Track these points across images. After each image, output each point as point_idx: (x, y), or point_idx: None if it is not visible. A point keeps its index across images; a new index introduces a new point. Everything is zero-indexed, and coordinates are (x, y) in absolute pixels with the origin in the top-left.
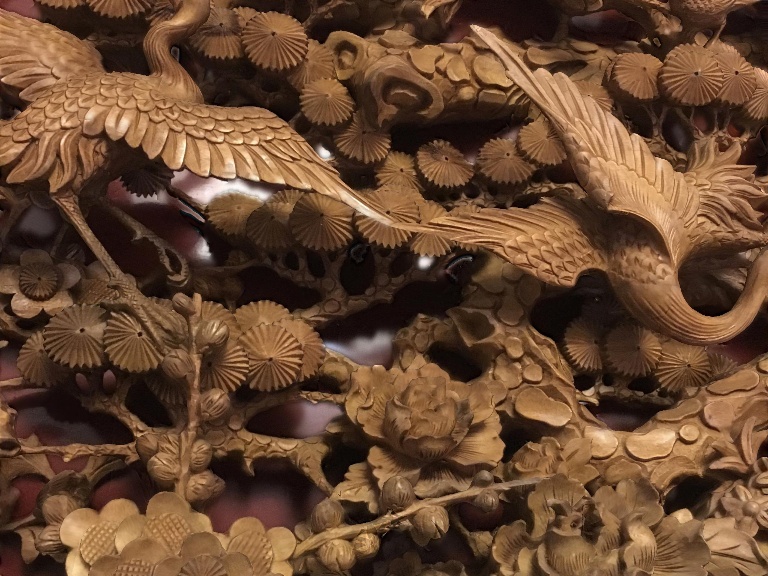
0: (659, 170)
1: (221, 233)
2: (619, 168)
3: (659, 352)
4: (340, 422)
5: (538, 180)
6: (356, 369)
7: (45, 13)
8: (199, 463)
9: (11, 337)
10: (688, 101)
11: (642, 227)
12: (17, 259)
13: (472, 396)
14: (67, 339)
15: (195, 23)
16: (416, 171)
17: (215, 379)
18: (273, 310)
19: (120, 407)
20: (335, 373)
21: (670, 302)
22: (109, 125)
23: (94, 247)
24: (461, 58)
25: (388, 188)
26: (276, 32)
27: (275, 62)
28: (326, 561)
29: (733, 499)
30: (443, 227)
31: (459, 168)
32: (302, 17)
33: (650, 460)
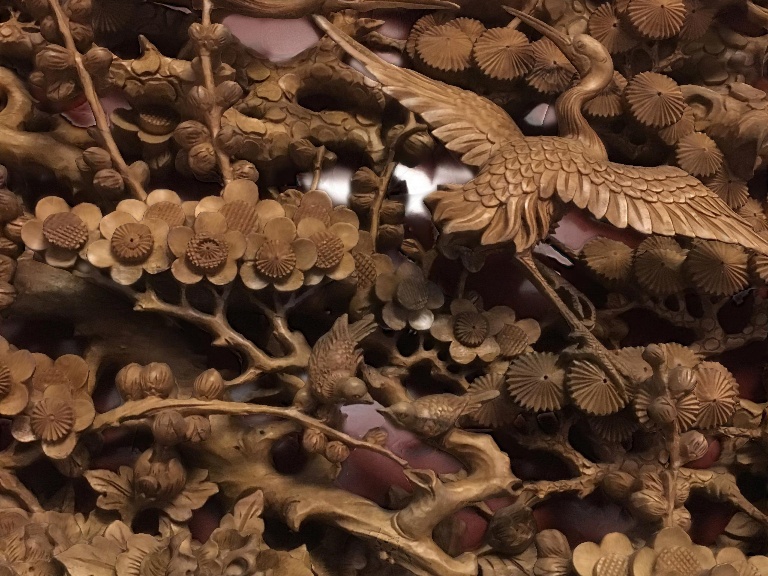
0: None
1: (601, 278)
2: None
3: None
4: (748, 454)
5: None
6: (738, 403)
7: (429, 75)
8: (683, 499)
9: (438, 380)
10: None
11: None
12: (447, 309)
13: None
14: (532, 386)
15: (603, 88)
16: (766, 215)
17: None
18: (683, 352)
19: (566, 445)
20: None
21: None
22: (560, 188)
23: (557, 301)
24: None
25: (763, 235)
26: (662, 92)
27: (658, 119)
28: None
29: None
30: None
31: None
32: (644, 71)
33: None
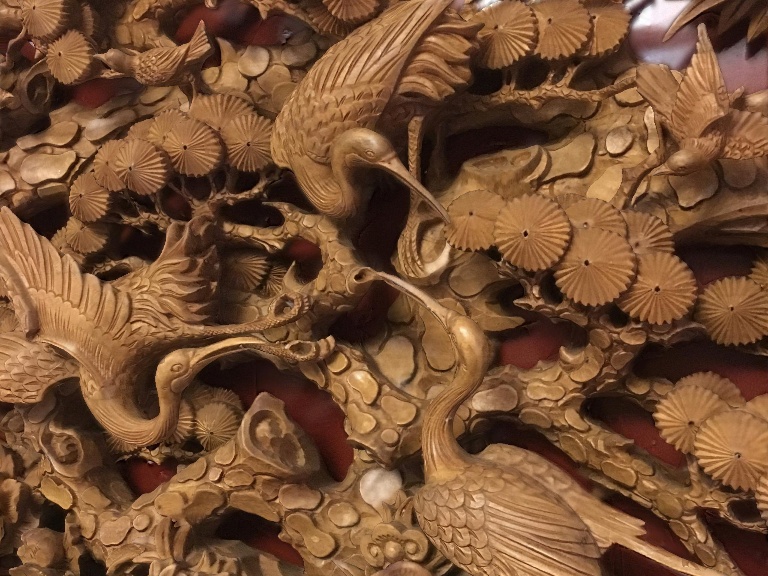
0: (86, 288)
1: None
2: (46, 296)
3: (189, 421)
4: None
5: (99, 261)
6: None
7: None
8: None
9: None
10: (140, 192)
11: None
12: None
13: None
14: None
15: None
16: None
17: None
18: None
19: None
20: None
21: (100, 415)
22: None
23: None
24: (8, 167)
25: None
26: None
27: None
28: None
29: None
30: None
31: None
32: None
33: (110, 546)
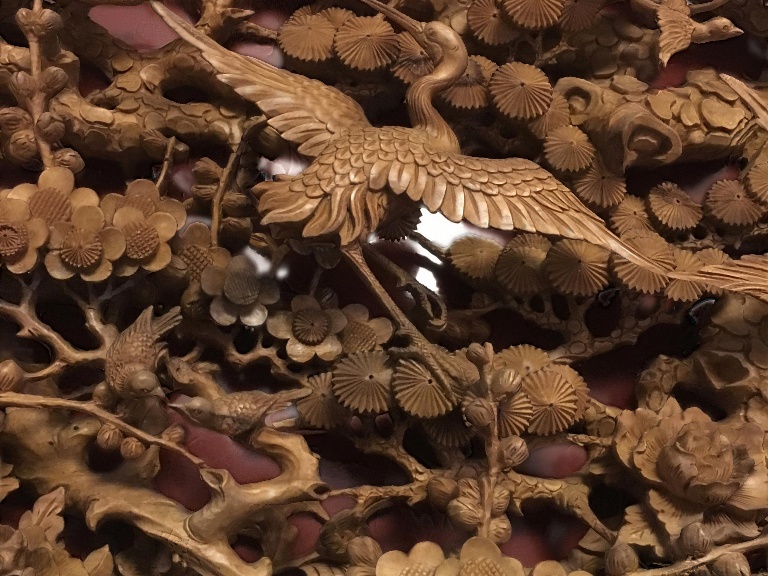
0: None
1: (465, 276)
2: None
3: None
4: (602, 464)
5: (765, 221)
6: (604, 410)
7: (292, 65)
8: (500, 508)
9: (280, 379)
10: None
11: None
12: (288, 305)
13: (740, 440)
14: (357, 385)
15: (455, 77)
16: (648, 214)
17: (502, 425)
18: (534, 354)
19: (399, 449)
20: None
21: None
22: (392, 179)
23: (383, 297)
24: None
25: (633, 233)
26: (525, 83)
27: (522, 111)
28: None
29: None
30: (713, 275)
31: (689, 210)
32: (527, 63)
33: None
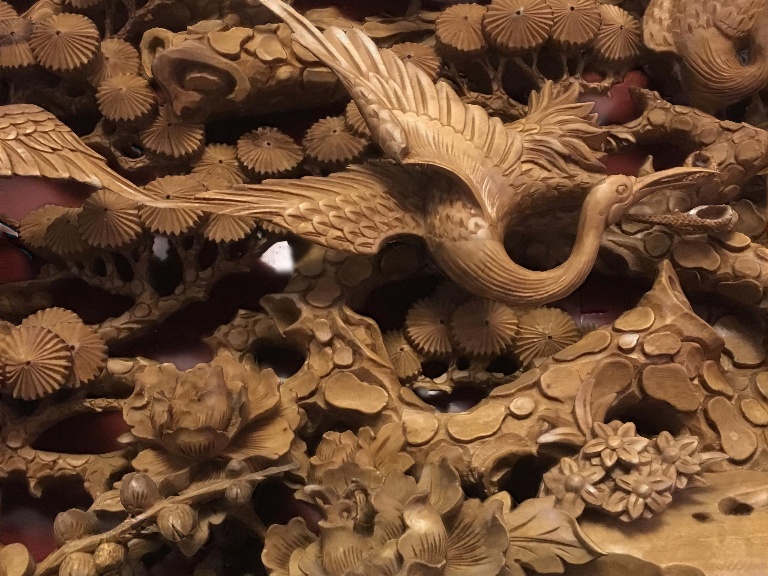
0: (470, 117)
1: (30, 247)
2: (419, 119)
3: (515, 326)
4: None
5: (375, 156)
6: None
7: None
8: None
9: None
10: (515, 45)
11: (450, 180)
12: None
13: (261, 385)
14: None
15: None
16: (238, 161)
17: None
18: (59, 316)
19: None
20: None
21: (485, 258)
22: None
23: None
24: (277, 38)
25: None
26: (61, 31)
27: (64, 62)
28: None
29: (555, 474)
30: (211, 201)
31: (284, 152)
32: (121, 23)
33: (473, 441)
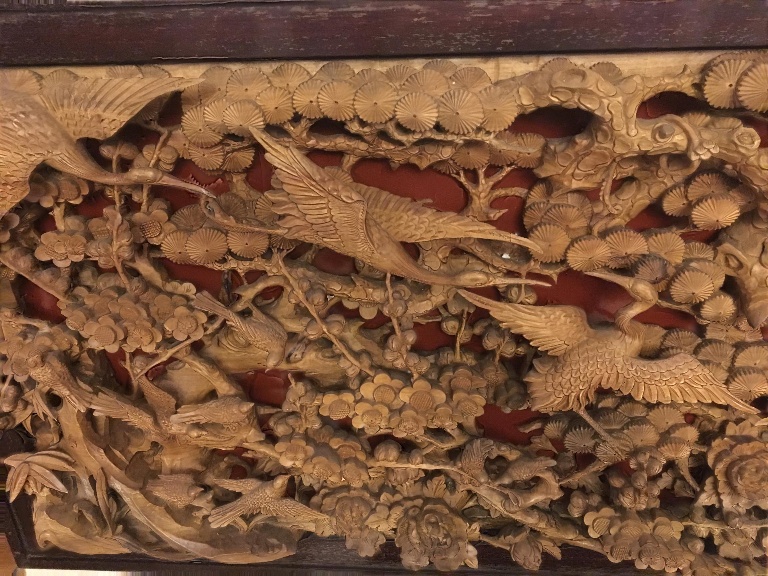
0: None
1: None
2: None
3: None
4: None
5: None
6: (708, 412)
7: None
8: None
9: None
10: None
11: None
12: None
13: None
14: (577, 447)
15: None
16: None
17: None
18: (672, 413)
19: None
20: (696, 413)
21: None
22: (603, 384)
23: (594, 427)
24: None
25: (748, 352)
26: (695, 293)
27: (690, 301)
28: (697, 534)
29: None
30: None
31: None
32: None
33: None
